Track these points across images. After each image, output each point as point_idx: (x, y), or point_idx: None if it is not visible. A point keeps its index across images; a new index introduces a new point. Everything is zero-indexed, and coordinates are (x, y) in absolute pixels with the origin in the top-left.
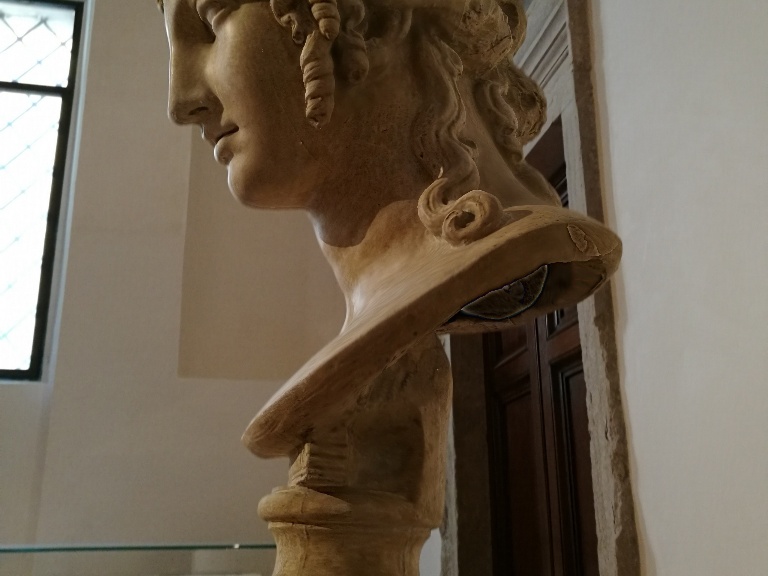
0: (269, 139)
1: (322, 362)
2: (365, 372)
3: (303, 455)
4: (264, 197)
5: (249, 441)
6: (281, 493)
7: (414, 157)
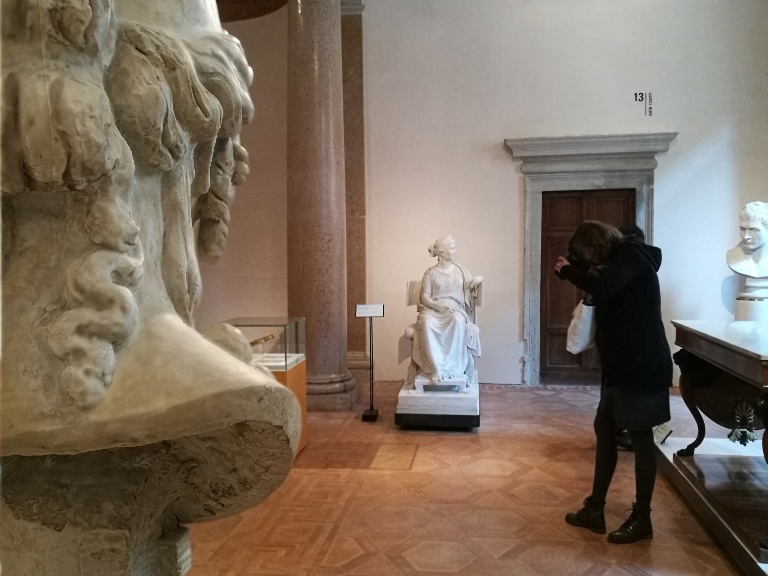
0: None
1: None
2: None
3: None
4: None
5: None
6: None
7: None
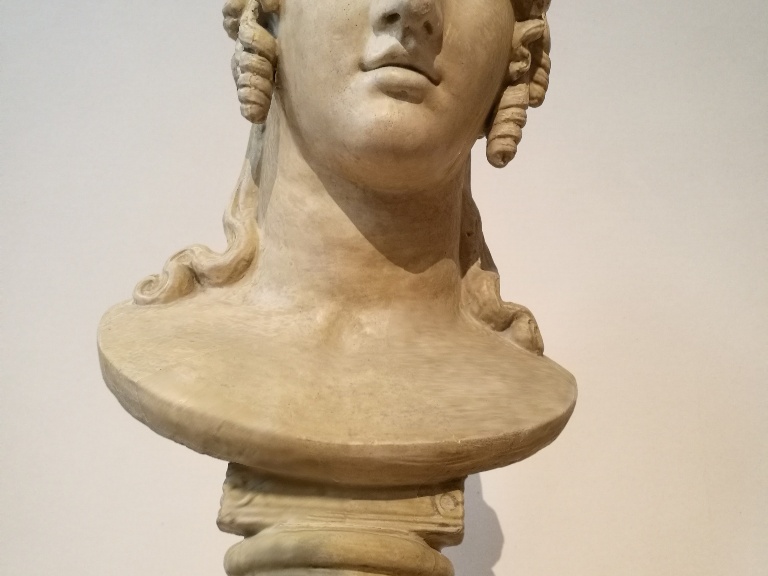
0: (459, 128)
1: (543, 421)
2: (545, 444)
3: (441, 500)
4: (404, 166)
5: (370, 456)
6: (398, 538)
7: (461, 229)
